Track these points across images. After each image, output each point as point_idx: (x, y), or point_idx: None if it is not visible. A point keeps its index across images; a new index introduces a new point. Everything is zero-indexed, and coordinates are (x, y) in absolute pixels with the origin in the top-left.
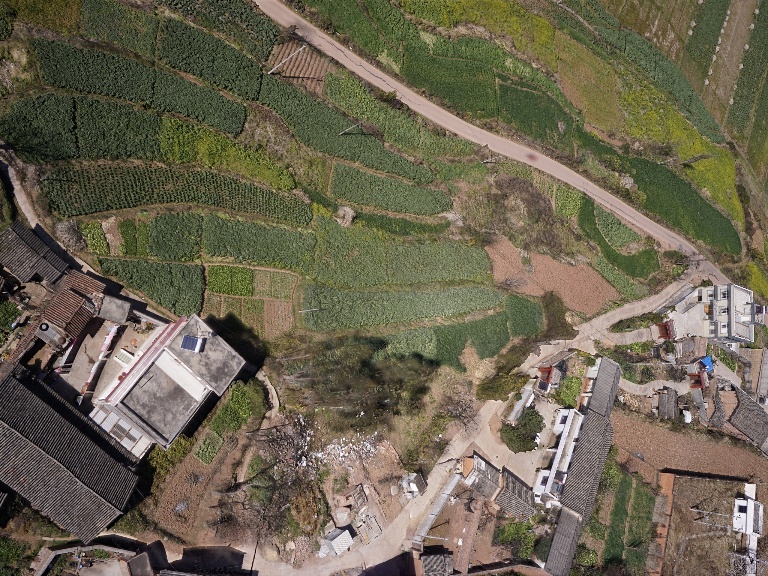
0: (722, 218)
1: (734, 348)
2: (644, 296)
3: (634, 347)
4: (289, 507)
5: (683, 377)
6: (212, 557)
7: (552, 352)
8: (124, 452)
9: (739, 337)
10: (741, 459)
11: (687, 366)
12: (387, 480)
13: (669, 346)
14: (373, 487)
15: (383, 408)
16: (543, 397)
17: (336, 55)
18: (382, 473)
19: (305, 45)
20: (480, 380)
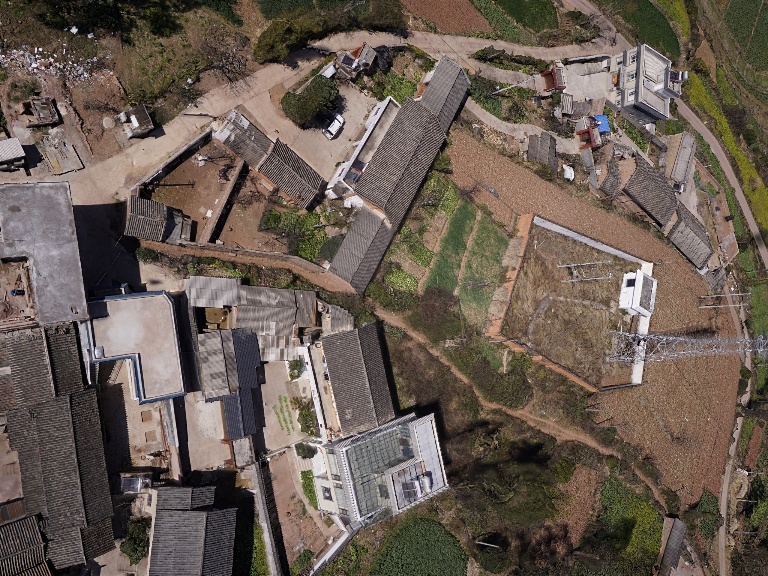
0: (655, 11)
1: (648, 129)
2: (531, 45)
3: None
4: None
5: (570, 135)
6: None
7: (378, 45)
8: None
9: (648, 105)
10: (641, 241)
11: (576, 122)
12: (98, 108)
13: (554, 97)
14: (72, 107)
15: (102, 24)
16: (354, 84)
17: None
18: (91, 98)
19: None
20: None
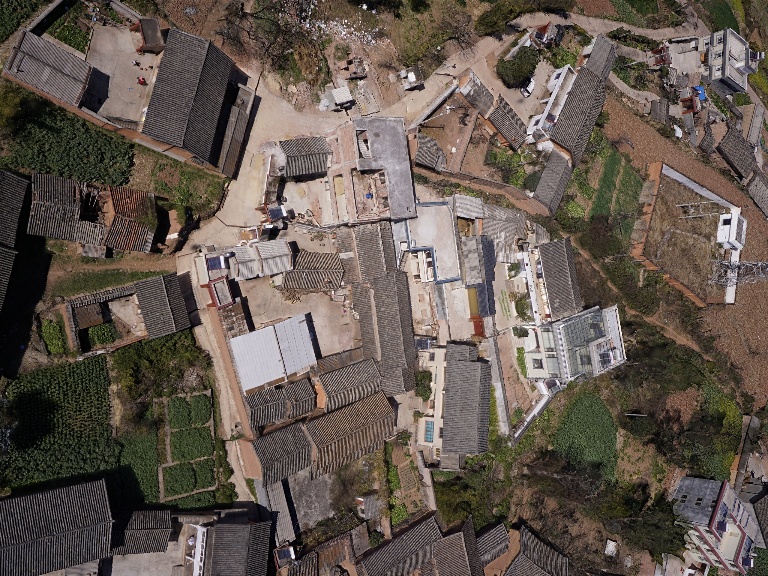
0: (722, 0)
1: None
2: (642, 27)
3: (629, 61)
4: (292, 52)
5: (676, 102)
6: None
7: None
8: None
9: (732, 79)
10: (728, 191)
11: (680, 92)
12: (386, 67)
13: (664, 70)
14: None
15: (385, 3)
16: (539, 54)
17: None
18: (382, 59)
19: None
20: (479, 16)
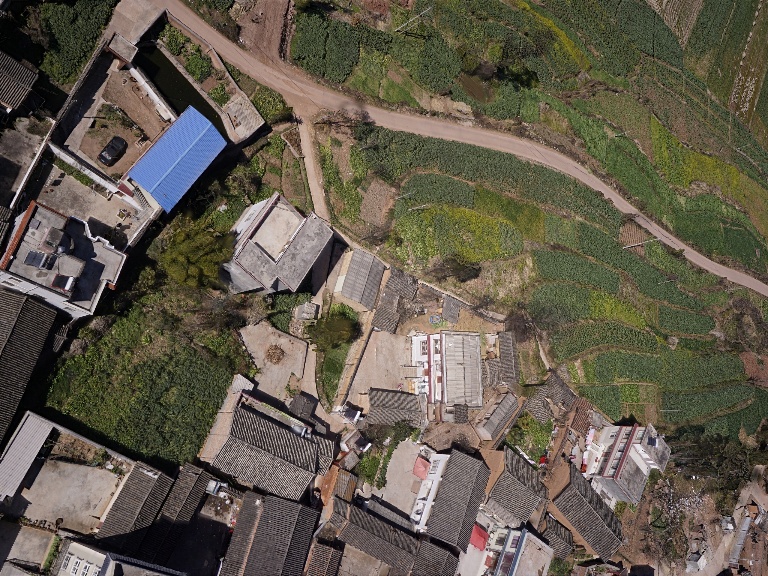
0: None
1: None
2: None
3: None
4: (671, 540)
5: None
6: (642, 572)
7: None
8: (608, 507)
9: None
10: None
11: None
12: (713, 521)
13: None
14: None
15: None
16: None
17: (647, 226)
18: (710, 517)
19: (633, 223)
20: (750, 451)
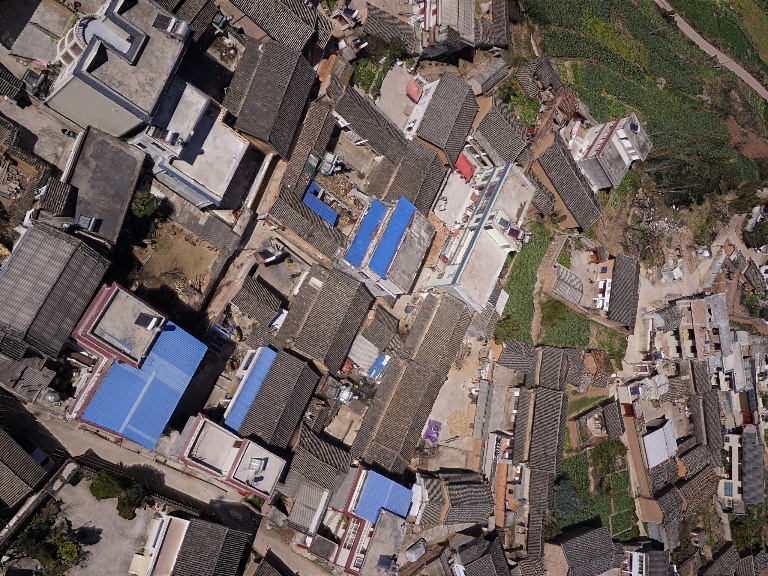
0: None
1: None
2: None
3: None
4: (649, 248)
5: None
6: None
7: (762, 196)
8: None
9: None
10: None
11: None
12: (690, 247)
13: None
14: None
15: (686, 204)
16: None
17: None
18: (688, 242)
19: None
20: (730, 201)
